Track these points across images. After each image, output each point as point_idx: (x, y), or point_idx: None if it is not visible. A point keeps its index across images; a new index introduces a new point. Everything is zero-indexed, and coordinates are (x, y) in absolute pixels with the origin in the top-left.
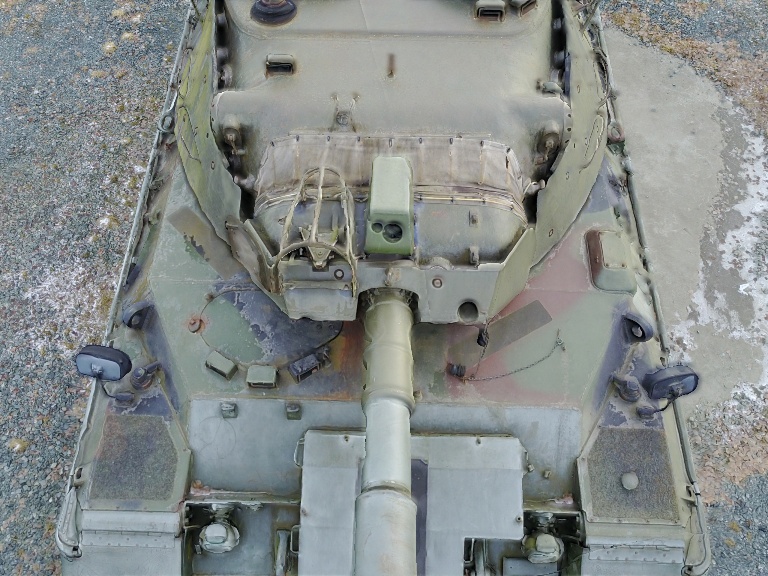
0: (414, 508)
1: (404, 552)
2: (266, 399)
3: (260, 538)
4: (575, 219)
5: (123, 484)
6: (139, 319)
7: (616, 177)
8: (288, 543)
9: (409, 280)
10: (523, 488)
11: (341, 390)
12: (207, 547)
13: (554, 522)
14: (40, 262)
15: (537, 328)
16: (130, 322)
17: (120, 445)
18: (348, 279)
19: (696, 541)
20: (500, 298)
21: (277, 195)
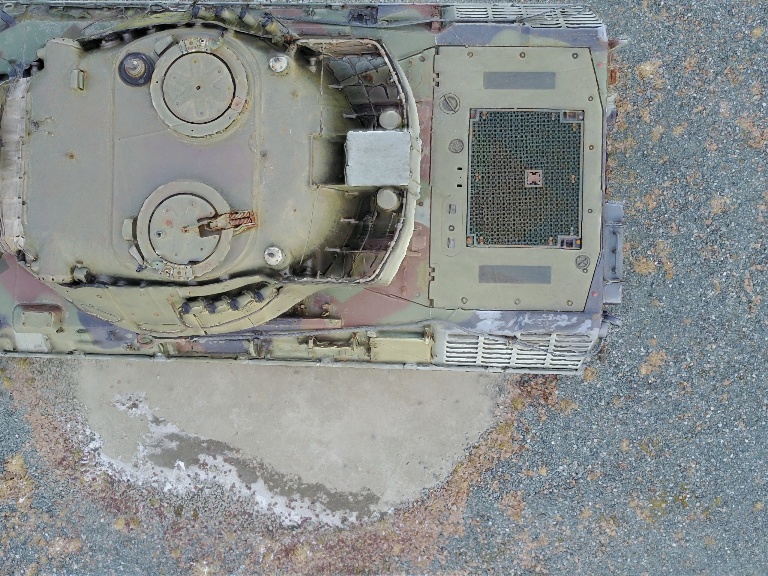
0: None
1: None
2: None
3: None
4: None
5: None
6: None
7: (135, 343)
8: None
9: None
10: None
11: None
12: None
13: None
14: None
15: None
16: None
17: None
18: None
19: None
20: None
21: (6, 90)
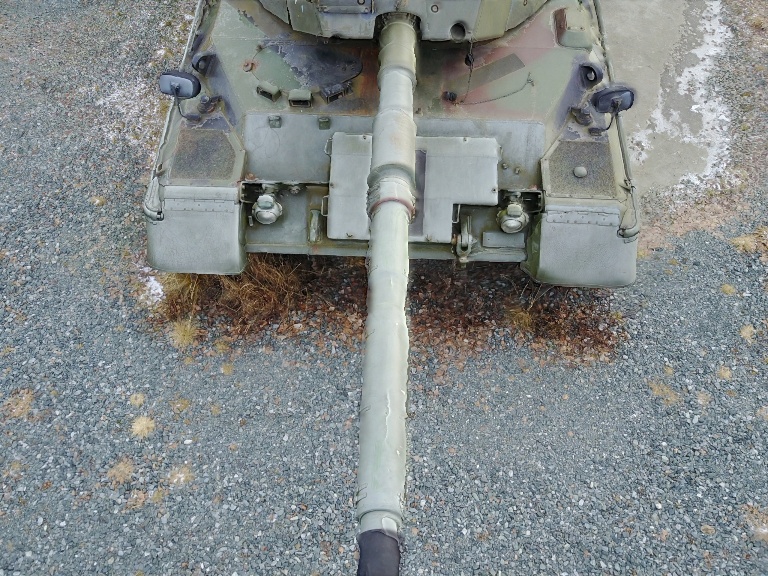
0: (414, 125)
1: (407, 139)
2: (303, 114)
3: (297, 217)
4: (546, 2)
5: (195, 170)
6: (204, 65)
7: None
8: (319, 218)
9: (414, 6)
10: (499, 181)
11: (361, 109)
12: (258, 217)
13: (522, 202)
14: (109, 80)
15: (513, 71)
16: (198, 65)
17: (191, 147)
18: (368, 4)
19: (629, 214)
20: (482, 26)
21: None
